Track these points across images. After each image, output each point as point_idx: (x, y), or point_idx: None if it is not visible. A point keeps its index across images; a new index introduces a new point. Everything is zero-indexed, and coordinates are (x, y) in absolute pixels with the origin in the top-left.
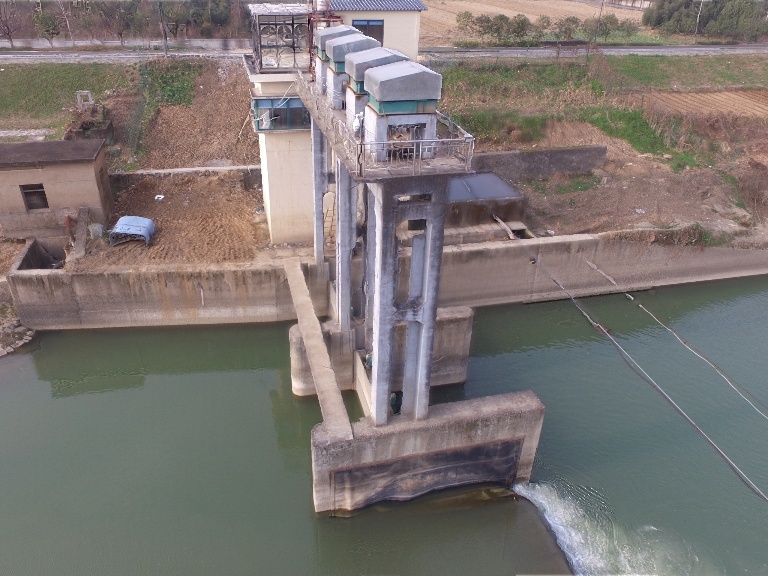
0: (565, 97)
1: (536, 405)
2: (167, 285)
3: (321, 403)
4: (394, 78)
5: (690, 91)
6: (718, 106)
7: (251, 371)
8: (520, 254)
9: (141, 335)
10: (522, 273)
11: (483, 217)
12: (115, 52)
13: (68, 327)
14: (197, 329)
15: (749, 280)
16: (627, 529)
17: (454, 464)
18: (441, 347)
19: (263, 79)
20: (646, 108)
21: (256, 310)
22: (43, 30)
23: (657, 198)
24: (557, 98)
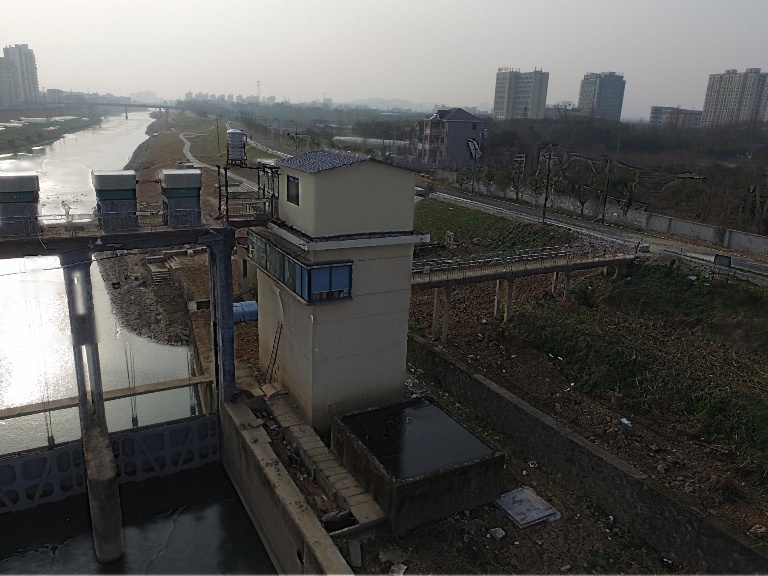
0: None
1: None
2: None
3: None
4: None
5: None
6: None
7: None
8: None
9: None
10: None
11: None
12: (553, 215)
13: None
14: None
15: None
16: None
17: None
18: None
19: None
20: None
21: None
22: (531, 189)
23: None
24: None
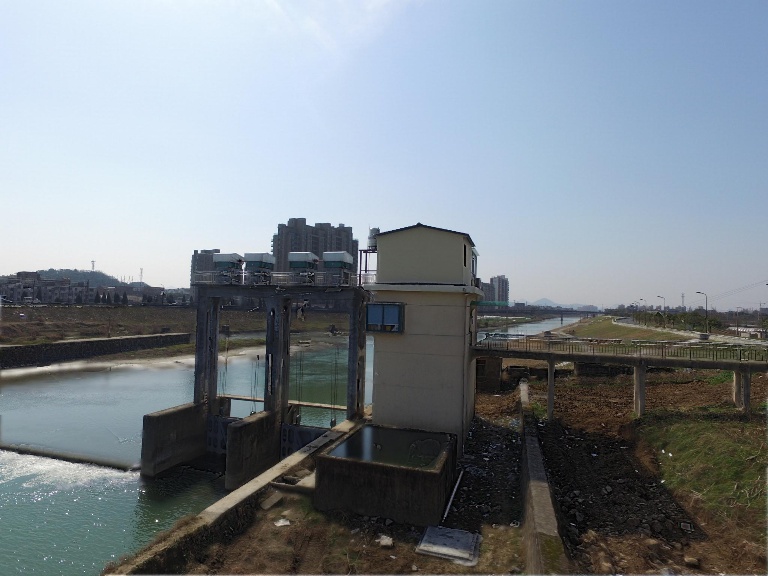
0: None
1: (149, 414)
2: None
3: None
4: None
5: None
6: None
7: None
8: None
9: None
10: None
11: None
12: None
13: None
14: None
15: None
16: None
17: None
18: None
19: None
20: None
21: None
22: None
23: None
24: None
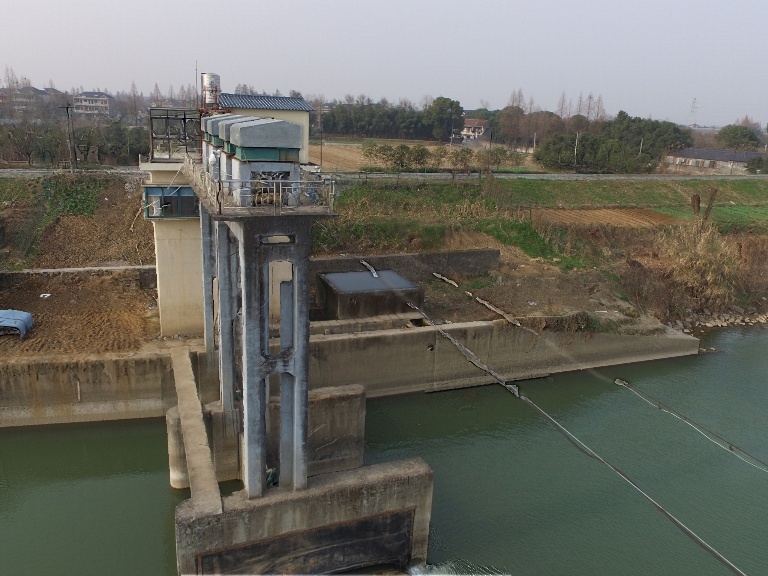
0: (462, 211)
1: (424, 470)
2: (39, 378)
3: (191, 479)
4: (254, 125)
5: (573, 208)
6: (598, 219)
7: (133, 476)
8: (417, 341)
9: (5, 437)
10: (421, 360)
11: (381, 308)
12: None
13: None
14: (71, 428)
15: (640, 366)
16: None
17: (340, 543)
18: (334, 428)
19: (153, 168)
20: (534, 219)
21: (139, 404)
22: None
23: (548, 293)
24: (454, 212)
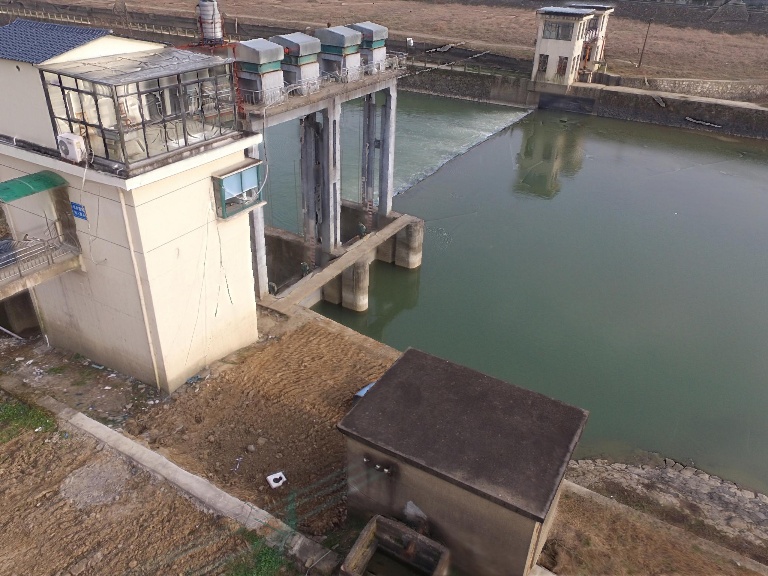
0: None
1: None
2: None
3: None
4: None
5: None
6: None
7: None
8: None
9: None
10: None
11: None
12: None
13: None
14: None
15: None
16: None
17: None
18: None
19: None
20: None
21: None
22: None
23: None
24: None
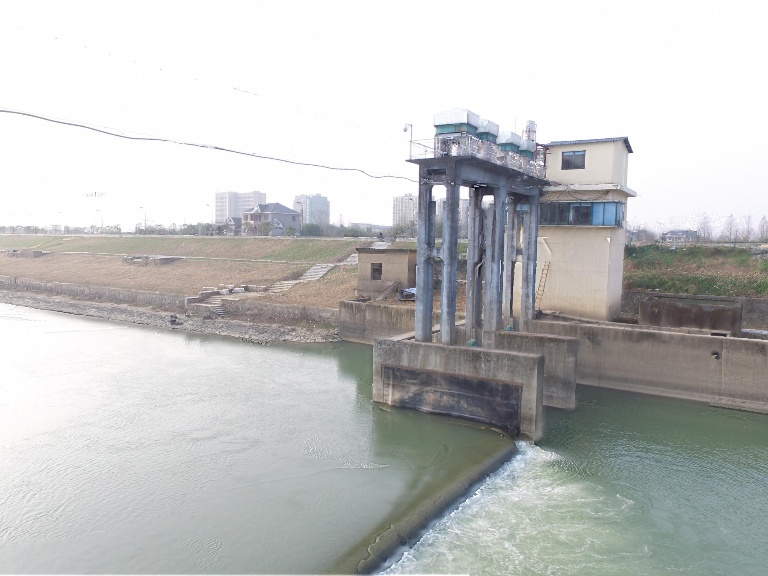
0: None
1: (533, 356)
2: (411, 319)
3: None
4: (441, 113)
5: None
6: None
7: None
8: (699, 345)
9: None
10: (704, 368)
11: (686, 320)
12: None
13: (358, 341)
14: None
15: None
16: (586, 489)
17: (465, 393)
18: None
19: None
20: None
21: None
22: None
23: None
24: None
